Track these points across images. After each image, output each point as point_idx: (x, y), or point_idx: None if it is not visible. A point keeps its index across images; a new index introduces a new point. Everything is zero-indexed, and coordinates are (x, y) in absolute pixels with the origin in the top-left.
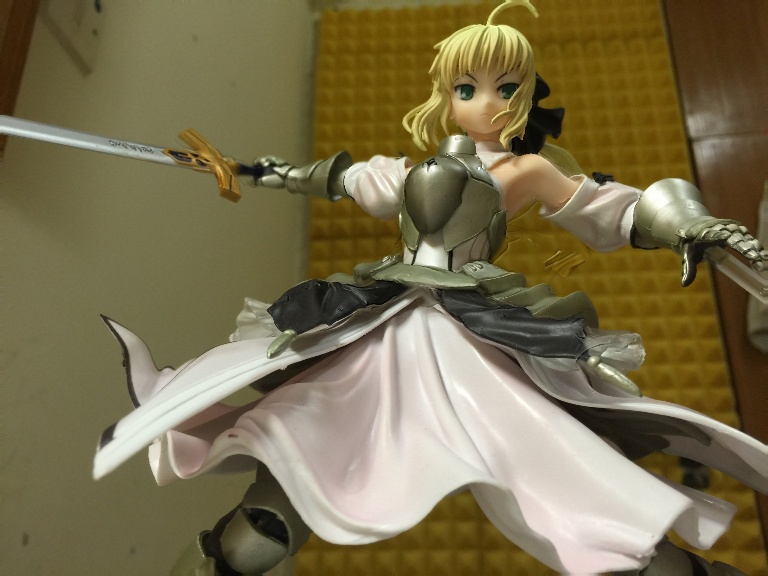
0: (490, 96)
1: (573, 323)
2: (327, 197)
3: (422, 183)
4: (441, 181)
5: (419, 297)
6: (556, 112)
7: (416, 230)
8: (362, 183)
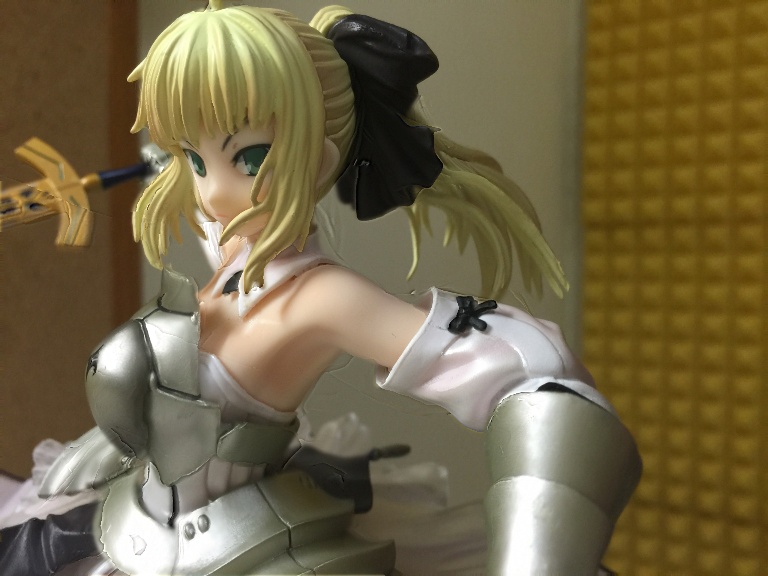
0: (220, 179)
1: None
2: None
3: None
4: (103, 404)
5: (143, 548)
6: (417, 135)
7: None
8: None
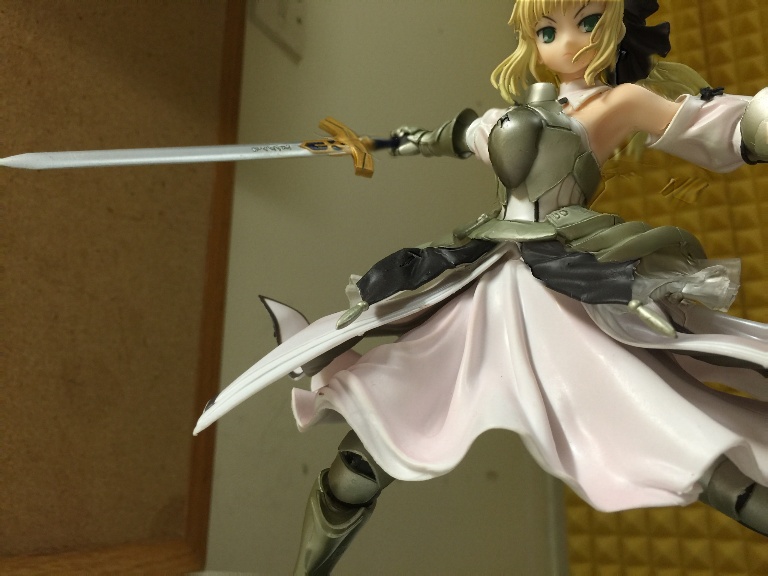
0: (570, 34)
1: (626, 266)
2: (456, 156)
3: (497, 141)
4: (514, 136)
5: (508, 251)
6: (660, 28)
7: (503, 186)
8: (477, 140)
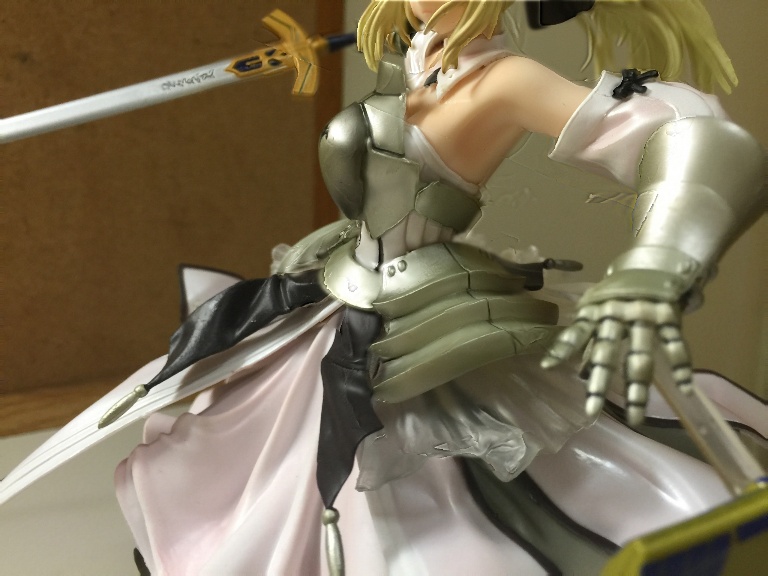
0: None
1: (365, 437)
2: None
3: None
4: (331, 163)
5: None
6: None
7: None
8: None
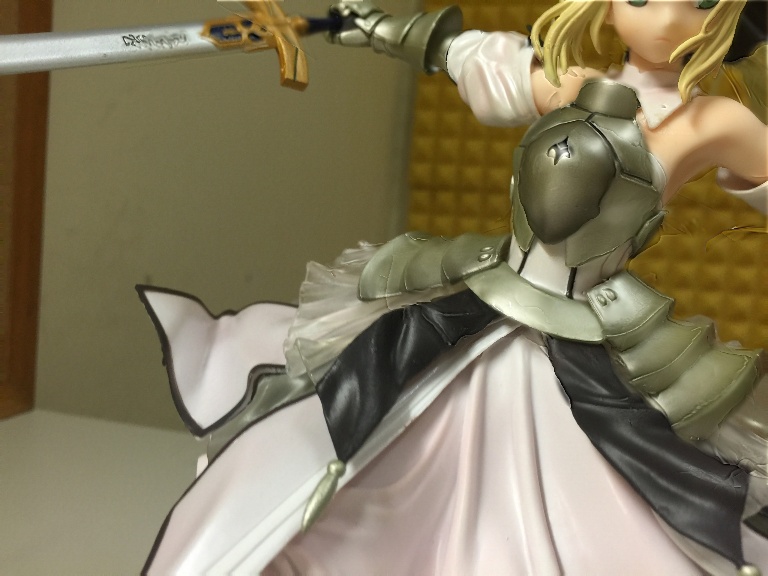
0: (676, 8)
1: (726, 479)
2: (424, 71)
3: (544, 181)
4: (572, 185)
5: (523, 325)
6: None
7: (530, 228)
8: (469, 79)
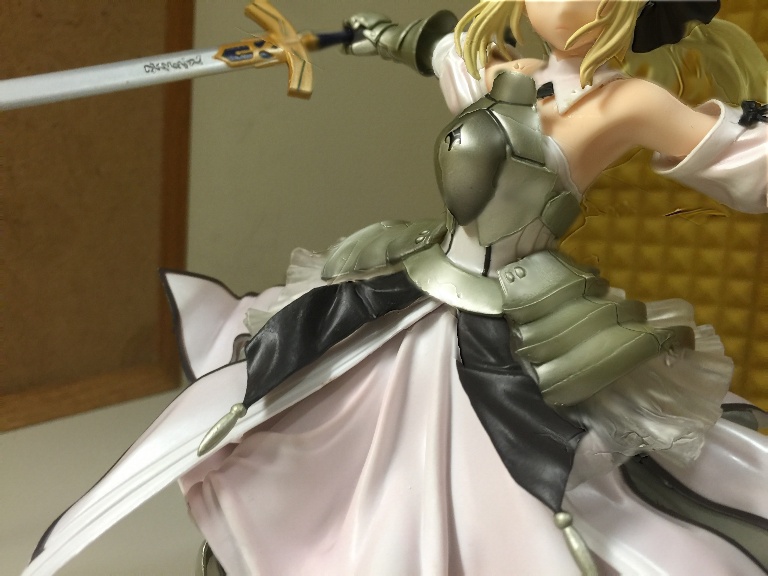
0: None
1: (569, 440)
2: (421, 73)
3: (443, 166)
4: (464, 168)
5: None
6: None
7: None
8: (442, 78)
